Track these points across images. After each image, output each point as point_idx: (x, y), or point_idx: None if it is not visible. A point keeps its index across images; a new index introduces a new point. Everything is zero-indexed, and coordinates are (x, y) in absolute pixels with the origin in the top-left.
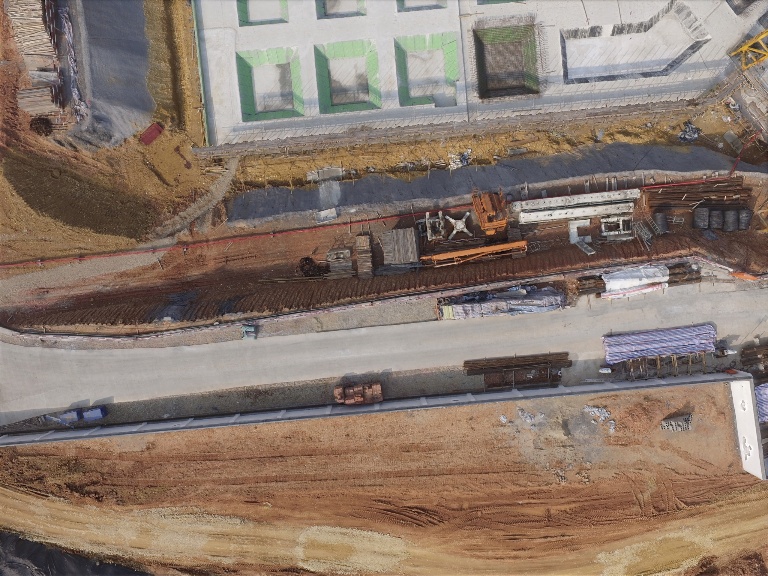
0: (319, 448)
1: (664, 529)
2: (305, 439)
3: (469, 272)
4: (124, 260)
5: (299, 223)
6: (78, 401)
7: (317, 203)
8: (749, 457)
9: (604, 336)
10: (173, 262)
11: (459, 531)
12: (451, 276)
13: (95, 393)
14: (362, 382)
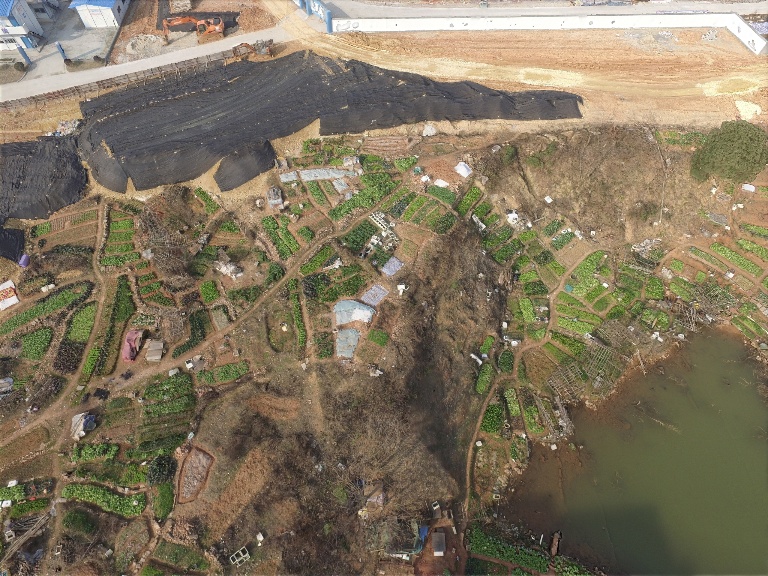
0: None
1: (728, 76)
2: (517, 37)
3: None
4: (415, 1)
5: None
6: None
7: None
8: (755, 45)
9: None
10: None
11: (611, 71)
12: None
13: None
14: None
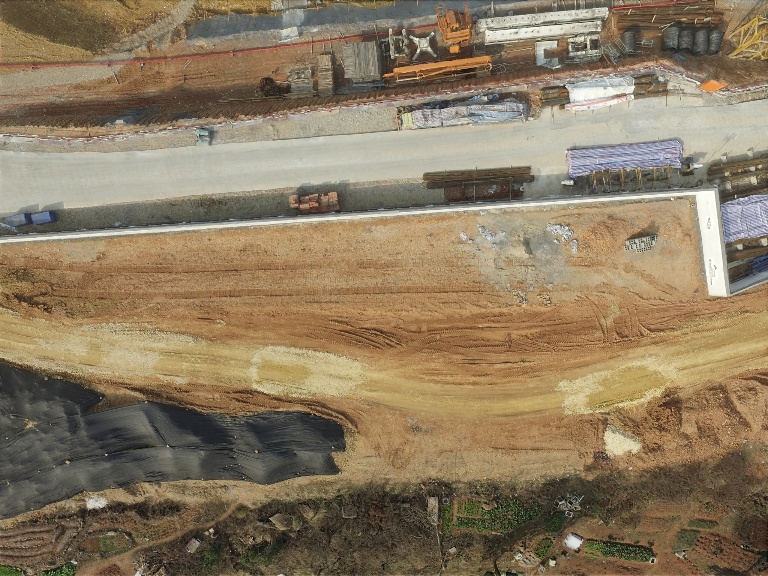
0: (274, 262)
1: (627, 357)
2: (260, 253)
3: (431, 87)
4: (79, 72)
5: (260, 42)
6: (27, 206)
7: (279, 25)
8: (714, 278)
9: (567, 150)
10: (130, 77)
11: (417, 354)
12: (412, 89)
13: (44, 198)
14: (319, 193)
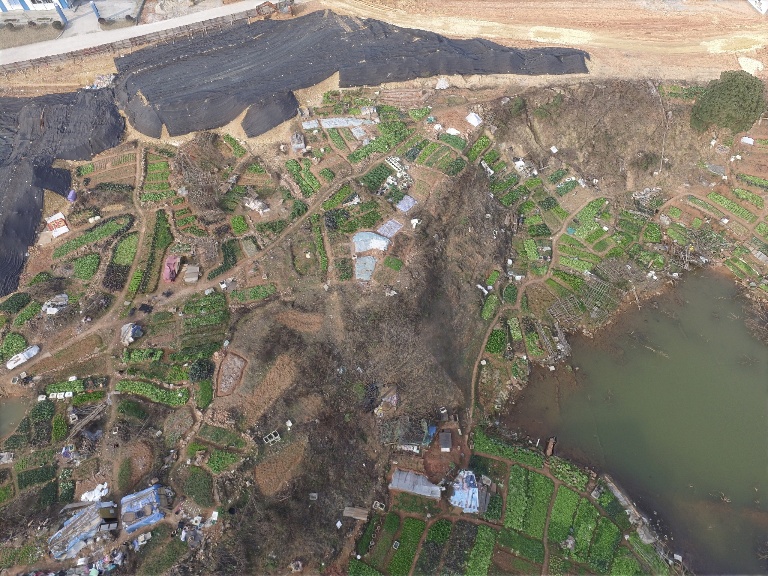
0: None
1: (733, 34)
2: None
3: None
4: None
5: None
6: None
7: None
8: None
9: None
10: None
11: (618, 30)
12: None
13: None
14: None
